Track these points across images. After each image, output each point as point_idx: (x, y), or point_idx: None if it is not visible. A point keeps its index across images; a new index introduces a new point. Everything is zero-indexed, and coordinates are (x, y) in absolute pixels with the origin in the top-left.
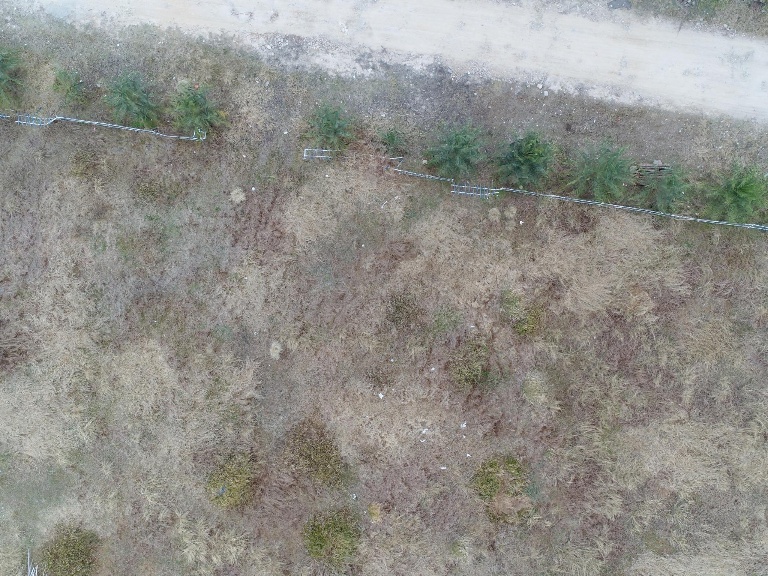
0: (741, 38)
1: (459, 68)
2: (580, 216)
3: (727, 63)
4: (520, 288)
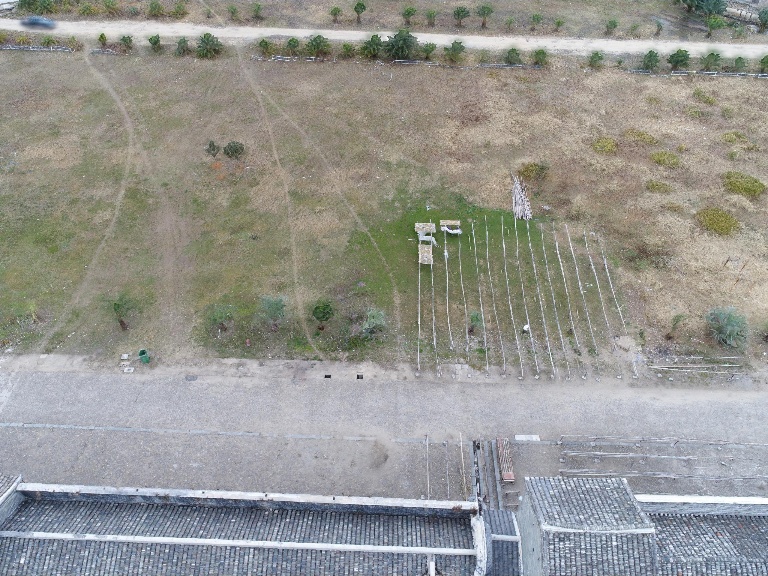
0: None
1: (634, 53)
2: None
3: None
4: None
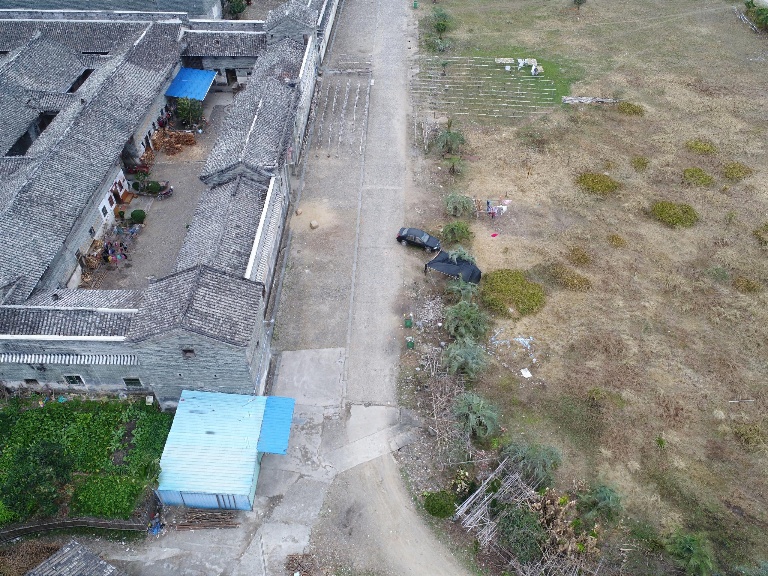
0: None
1: None
2: None
3: None
4: None
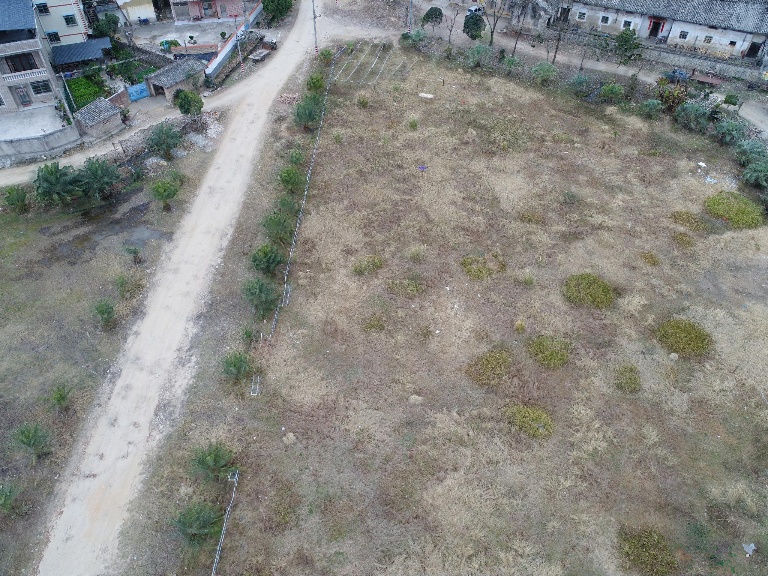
0: (200, 191)
1: (199, 307)
2: (303, 244)
3: (214, 195)
4: (351, 267)
